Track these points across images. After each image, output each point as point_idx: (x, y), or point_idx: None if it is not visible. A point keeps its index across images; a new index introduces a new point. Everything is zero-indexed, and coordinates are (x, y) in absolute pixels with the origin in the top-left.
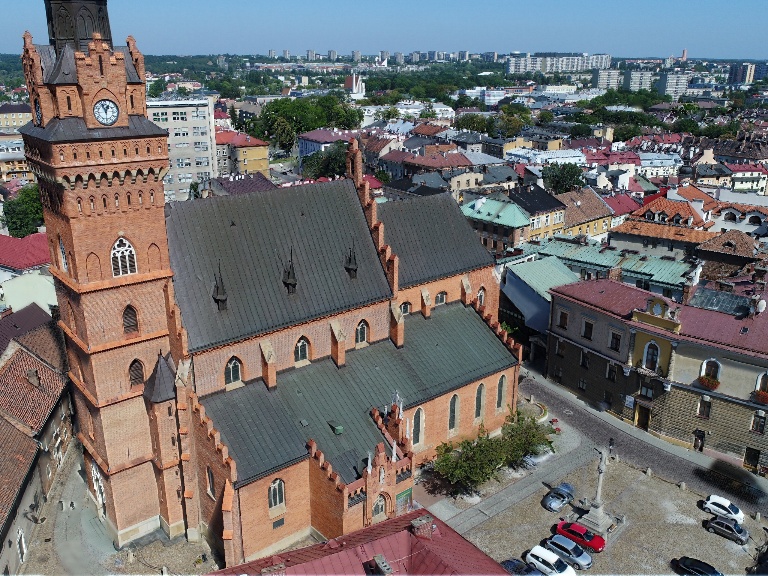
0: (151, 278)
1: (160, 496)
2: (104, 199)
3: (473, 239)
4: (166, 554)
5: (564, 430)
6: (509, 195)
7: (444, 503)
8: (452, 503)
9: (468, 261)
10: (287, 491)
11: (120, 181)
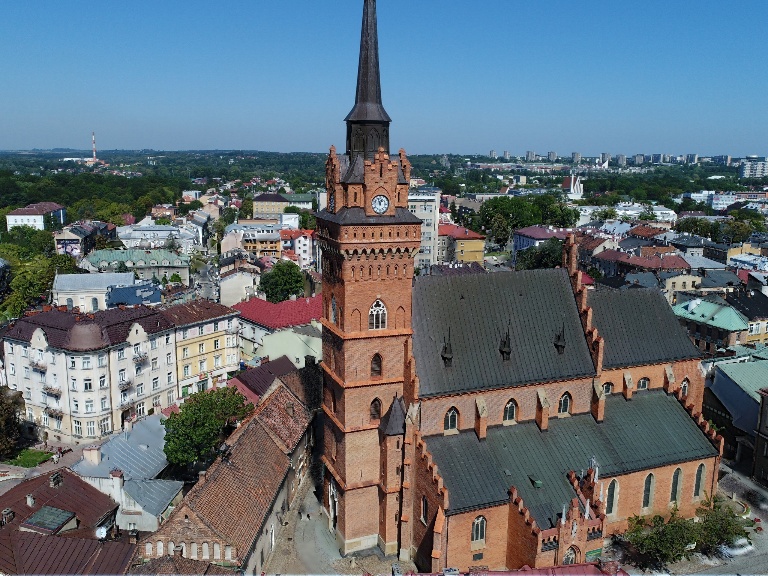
0: (396, 334)
1: (381, 517)
2: (370, 269)
3: (679, 332)
4: (381, 567)
5: (767, 531)
6: (726, 298)
7: (632, 573)
8: (640, 574)
9: (673, 352)
10: (488, 529)
11: (383, 256)
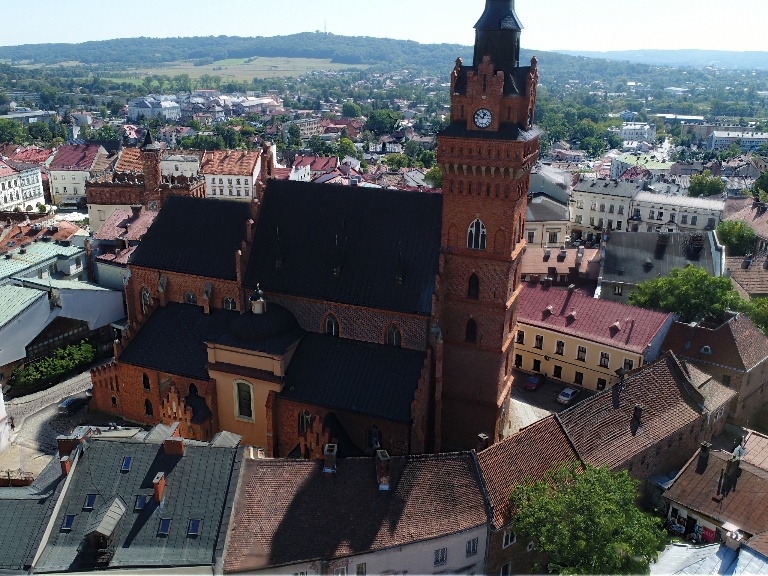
0: None
1: None
2: None
3: None
4: None
5: None
6: None
7: None
8: None
9: None
10: None
11: None
